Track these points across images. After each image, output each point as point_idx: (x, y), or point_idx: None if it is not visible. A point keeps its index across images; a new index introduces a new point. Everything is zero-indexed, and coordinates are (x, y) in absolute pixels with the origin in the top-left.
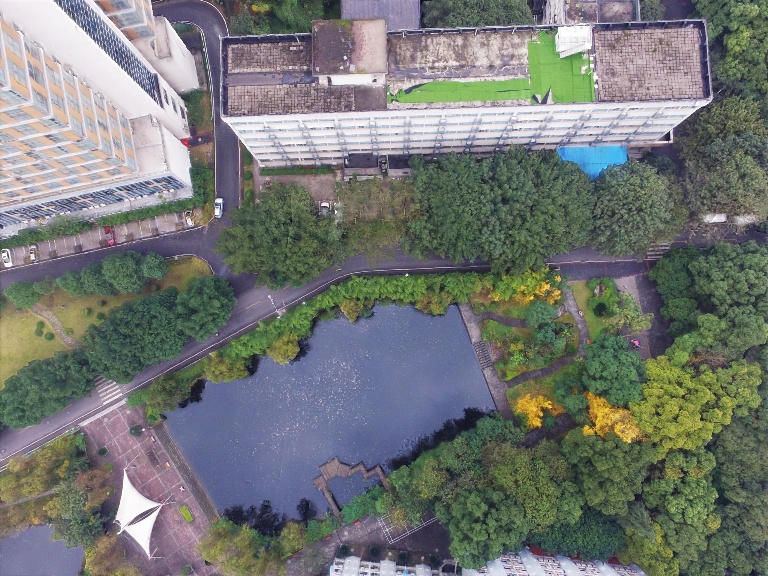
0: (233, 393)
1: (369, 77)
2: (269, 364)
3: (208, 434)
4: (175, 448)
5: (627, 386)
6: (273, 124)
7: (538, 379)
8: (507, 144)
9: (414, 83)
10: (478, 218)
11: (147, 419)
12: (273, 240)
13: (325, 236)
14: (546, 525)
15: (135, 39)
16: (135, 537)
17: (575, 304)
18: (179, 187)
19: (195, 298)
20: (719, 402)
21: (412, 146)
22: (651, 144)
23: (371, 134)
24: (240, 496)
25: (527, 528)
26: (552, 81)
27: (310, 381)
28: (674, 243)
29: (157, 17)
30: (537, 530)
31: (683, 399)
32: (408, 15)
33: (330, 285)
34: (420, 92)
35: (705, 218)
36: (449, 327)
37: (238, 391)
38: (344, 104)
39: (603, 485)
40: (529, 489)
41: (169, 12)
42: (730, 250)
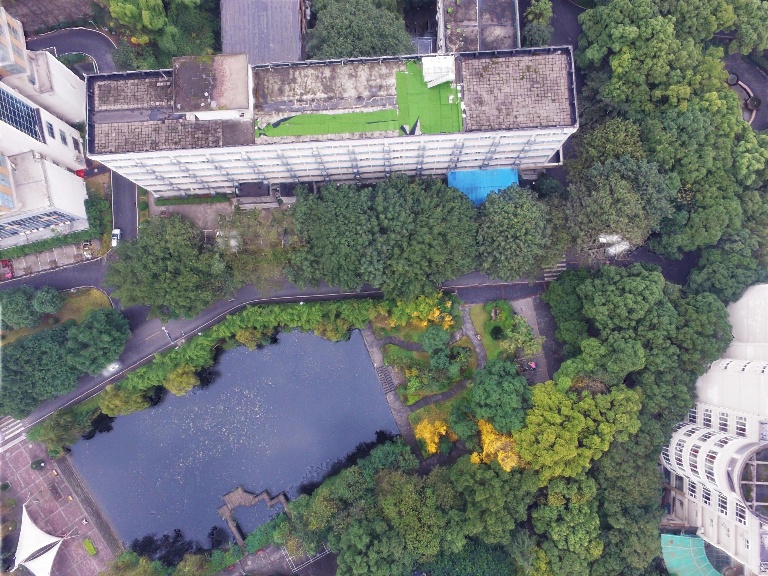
0: (136, 424)
1: (233, 112)
2: (172, 394)
3: (112, 466)
4: (78, 481)
5: (509, 413)
6: (145, 160)
7: (438, 403)
8: (395, 170)
9: (282, 116)
10: (356, 249)
11: (48, 453)
12: (153, 275)
13: (208, 269)
14: (431, 555)
15: (6, 77)
16: (34, 573)
17: (473, 327)
18: (75, 219)
19: (84, 333)
20: (598, 428)
21: (299, 175)
22: (542, 166)
23: (249, 166)
24: (144, 527)
25: (408, 559)
26: (420, 111)
27: (213, 410)
28: (571, 264)
29: (38, 52)
30: (422, 560)
31: (561, 426)
32: (289, 44)
33: (226, 315)
34: (288, 125)
35: (584, 243)
36: (352, 352)
37: (141, 422)
38: (212, 139)
39: (483, 514)
40: (411, 520)
41: (61, 43)
42: (614, 273)
